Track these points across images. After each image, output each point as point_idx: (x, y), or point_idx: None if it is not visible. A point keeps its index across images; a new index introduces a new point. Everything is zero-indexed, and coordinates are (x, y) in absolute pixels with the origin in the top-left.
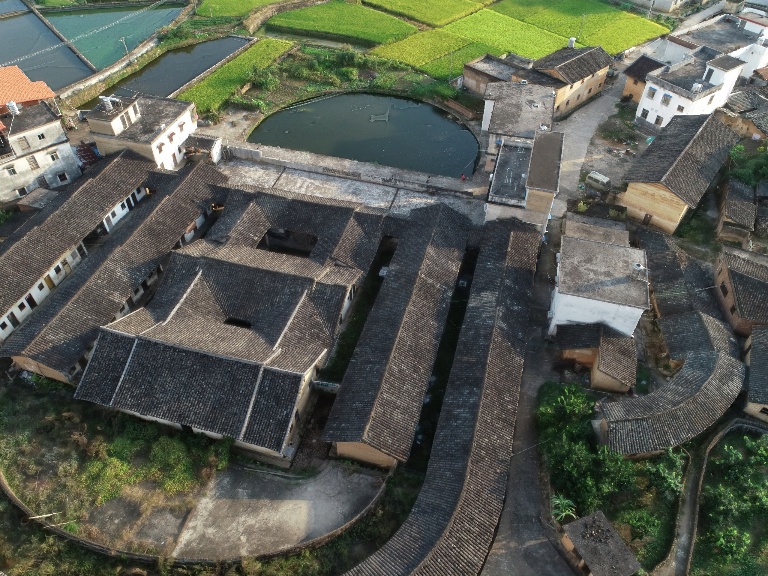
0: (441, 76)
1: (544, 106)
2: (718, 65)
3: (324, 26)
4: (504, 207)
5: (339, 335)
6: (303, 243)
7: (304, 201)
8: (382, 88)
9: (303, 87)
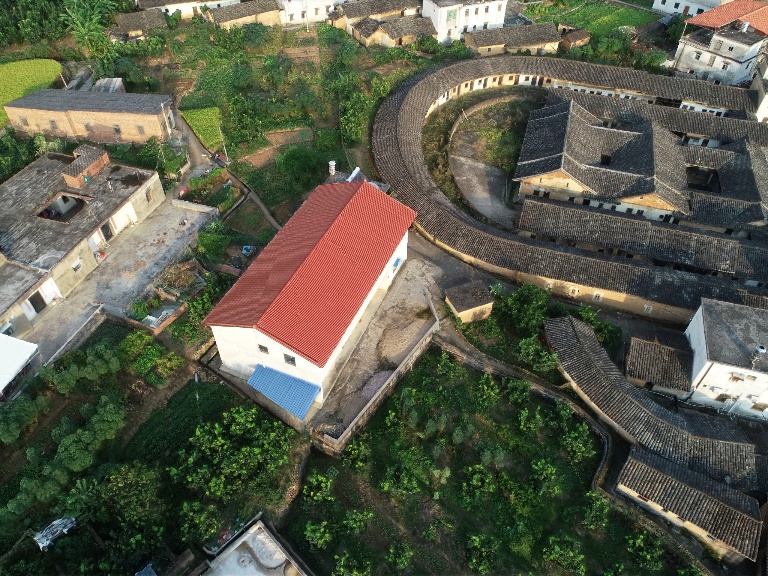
0: None
1: None
2: None
3: None
4: None
5: None
6: None
7: (754, 175)
8: None
9: None
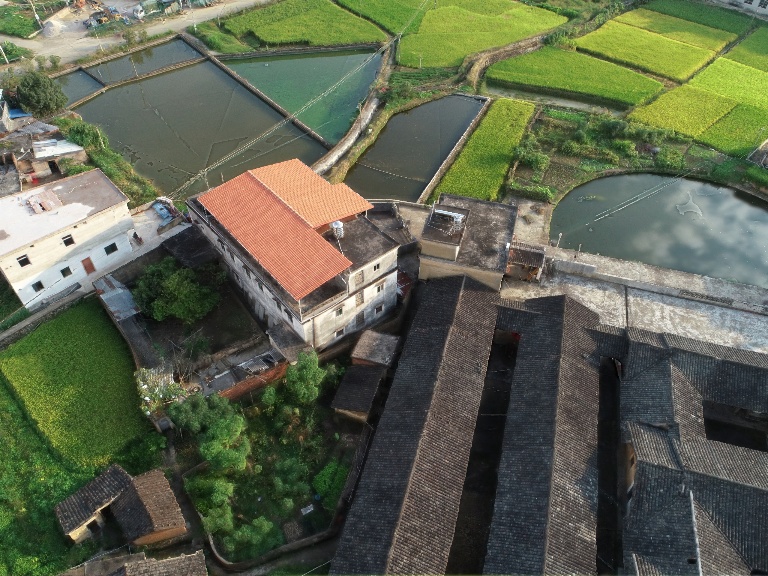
0: (733, 151)
1: None
2: None
3: (556, 81)
4: None
5: None
6: (724, 412)
7: (741, 363)
8: (673, 168)
9: (577, 165)
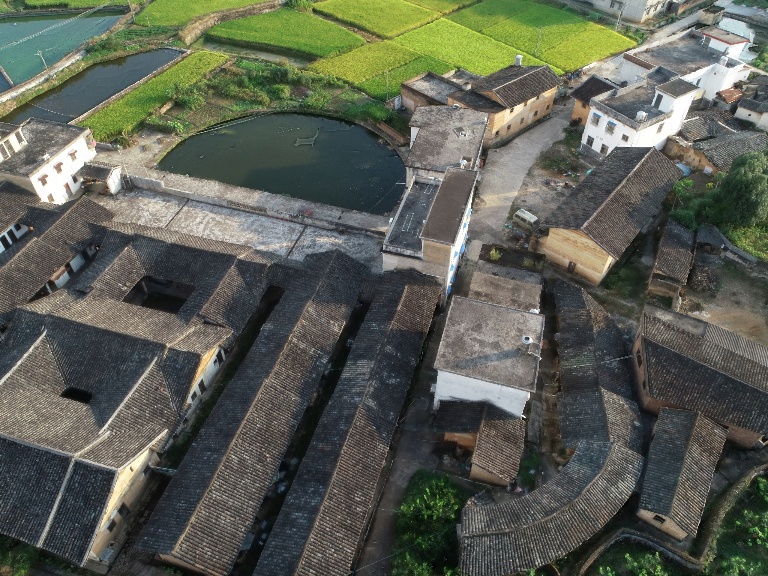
0: (379, 95)
1: (473, 135)
2: (667, 90)
3: (266, 37)
4: (400, 257)
5: (199, 405)
6: (186, 290)
7: (184, 246)
8: (313, 108)
9: (229, 106)
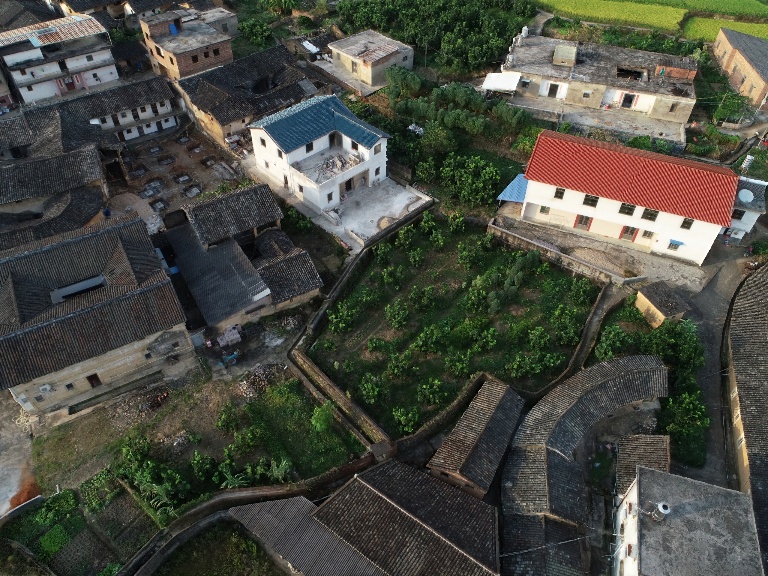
0: None
1: None
2: None
3: None
4: None
5: None
6: None
7: None
8: None
9: None
